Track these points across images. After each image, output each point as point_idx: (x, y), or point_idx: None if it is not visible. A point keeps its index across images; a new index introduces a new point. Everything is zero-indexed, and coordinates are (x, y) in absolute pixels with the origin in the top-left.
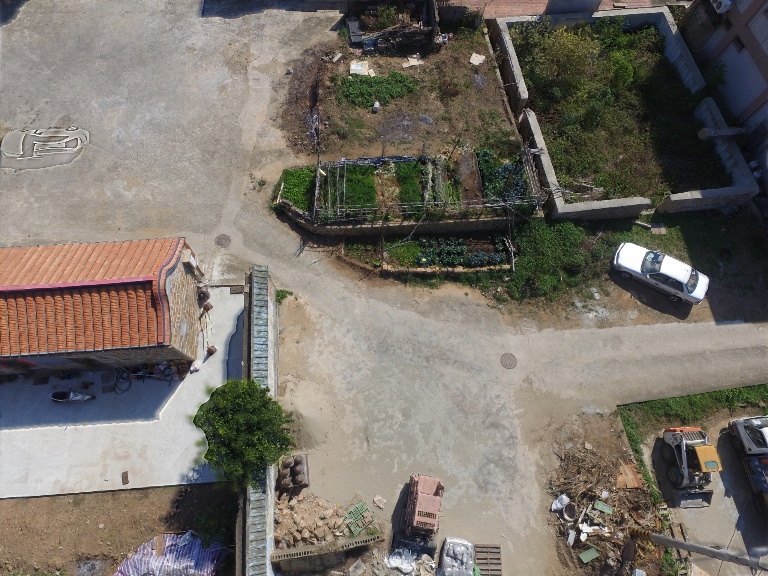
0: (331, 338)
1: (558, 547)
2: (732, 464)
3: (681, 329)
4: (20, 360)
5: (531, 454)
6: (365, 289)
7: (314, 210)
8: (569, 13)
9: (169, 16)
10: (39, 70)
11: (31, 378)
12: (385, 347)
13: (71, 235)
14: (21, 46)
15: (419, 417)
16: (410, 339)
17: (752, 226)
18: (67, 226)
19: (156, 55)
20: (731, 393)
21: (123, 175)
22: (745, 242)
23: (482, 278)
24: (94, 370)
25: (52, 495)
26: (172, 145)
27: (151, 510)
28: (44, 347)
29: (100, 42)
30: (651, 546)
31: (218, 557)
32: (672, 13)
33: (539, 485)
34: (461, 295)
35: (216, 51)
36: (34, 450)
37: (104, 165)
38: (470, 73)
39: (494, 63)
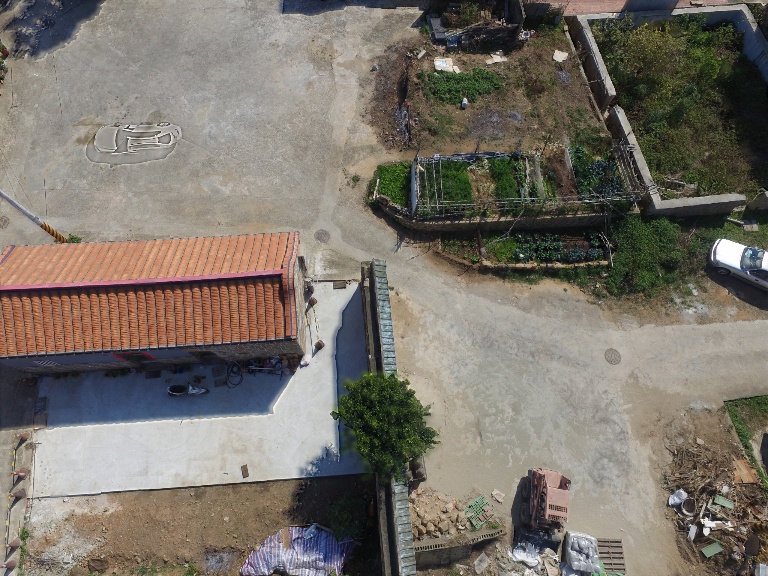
0: (435, 333)
1: (678, 542)
2: None
3: None
4: (138, 353)
5: (643, 449)
6: (464, 285)
7: (414, 206)
8: (648, 10)
9: (250, 12)
10: (126, 66)
11: (143, 372)
12: (489, 342)
13: (172, 230)
14: (106, 42)
15: (529, 412)
16: (513, 334)
17: None
18: (167, 221)
19: (241, 51)
20: None
21: (218, 170)
22: None
23: (580, 274)
24: (205, 364)
25: (173, 488)
26: (264, 141)
27: (274, 503)
28: (173, 340)
29: (184, 38)
30: None
31: (346, 550)
32: (752, 11)
33: (654, 480)
34: (560, 291)
35: (300, 47)
36: (152, 443)
37: (199, 160)
38: (554, 70)
39: (577, 60)
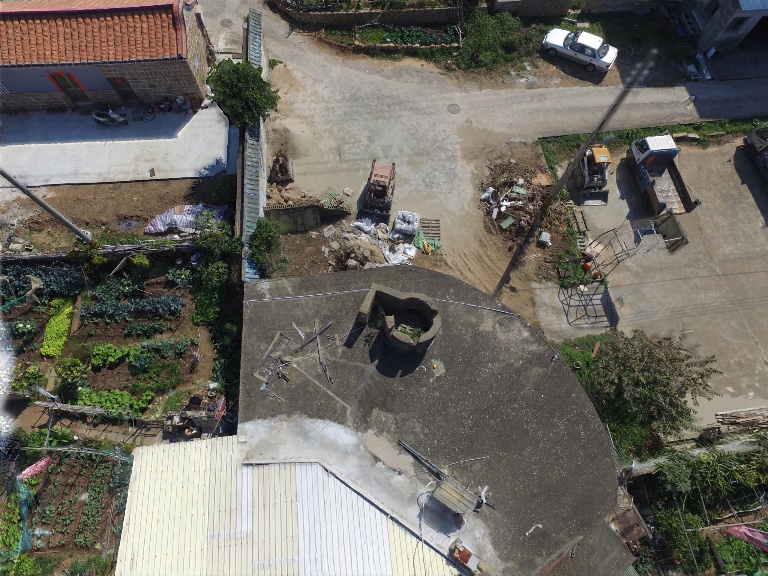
0: (313, 91)
1: (485, 222)
2: (628, 179)
3: (595, 90)
4: (70, 86)
5: (468, 166)
6: (341, 61)
7: None
8: None
9: None
10: None
11: (77, 111)
12: (355, 98)
13: None
14: None
15: (381, 142)
16: (376, 93)
17: (661, 23)
18: None
19: None
20: (630, 131)
21: None
22: (654, 33)
23: (435, 54)
24: (126, 106)
25: (97, 183)
26: None
27: (172, 191)
28: (91, 57)
29: None
30: (557, 222)
31: (224, 215)
32: None
33: (473, 185)
34: (418, 66)
35: None
36: (82, 156)
37: None
38: None
39: None
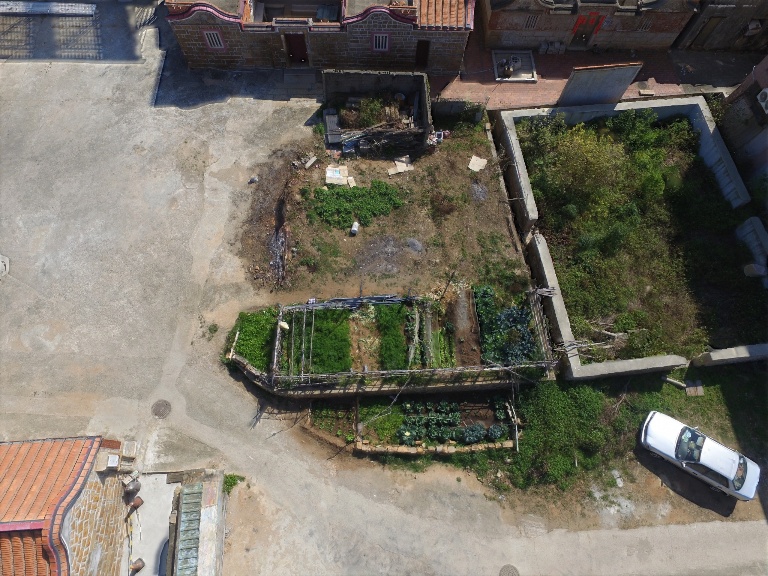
0: (289, 544)
1: None
2: None
3: (724, 530)
4: None
5: None
6: (334, 472)
7: None
8: (587, 105)
9: (116, 105)
10: None
11: None
12: (356, 557)
13: None
14: None
15: None
16: (387, 545)
17: None
18: None
19: (97, 156)
20: None
21: (46, 318)
22: None
23: None
24: None
25: None
26: (108, 277)
27: None
28: None
29: (32, 139)
30: None
31: None
32: (710, 107)
33: None
34: (452, 481)
35: (168, 151)
36: None
37: (24, 304)
38: (469, 182)
39: (497, 169)
